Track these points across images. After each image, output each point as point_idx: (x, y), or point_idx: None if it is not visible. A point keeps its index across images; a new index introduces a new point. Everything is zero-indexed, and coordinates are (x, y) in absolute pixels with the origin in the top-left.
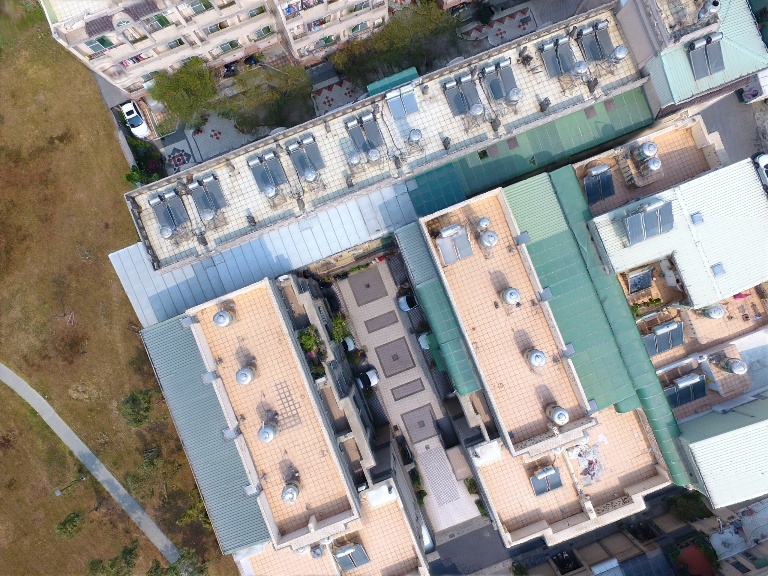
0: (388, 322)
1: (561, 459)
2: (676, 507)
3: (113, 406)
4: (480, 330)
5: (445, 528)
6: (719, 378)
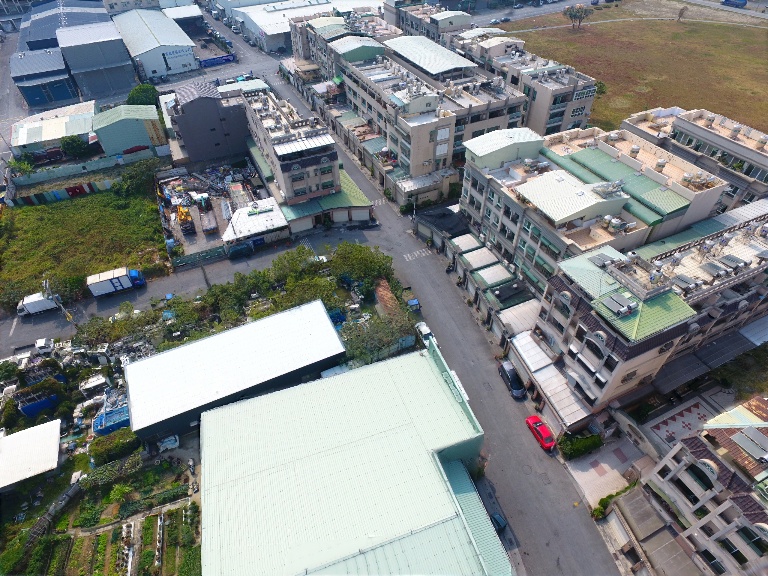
0: None
1: None
2: None
3: None
4: None
5: None
6: None
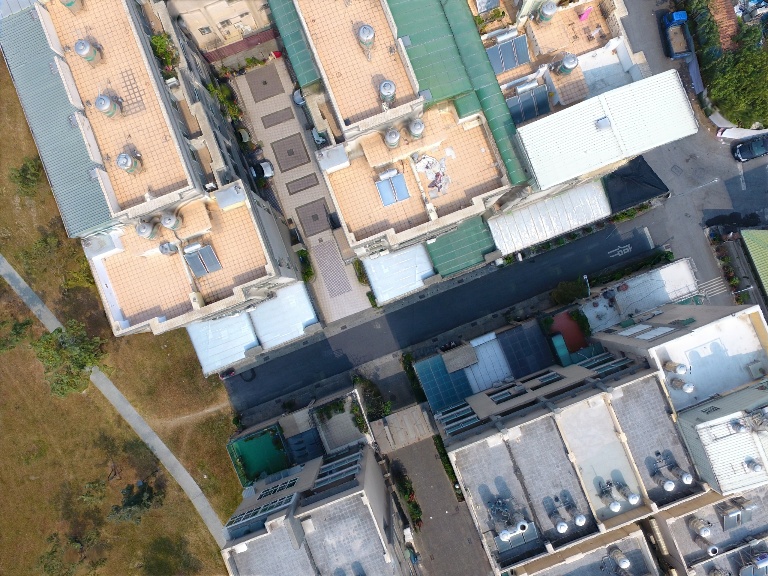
0: (284, 118)
1: (410, 172)
2: (557, 289)
3: (16, 202)
4: (320, 22)
5: (337, 319)
6: (559, 86)
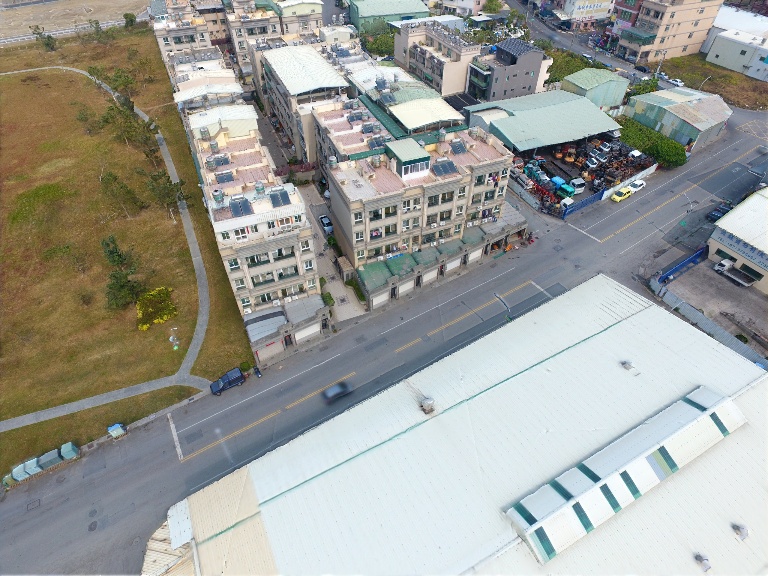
0: None
1: None
2: None
3: None
4: None
5: None
6: None
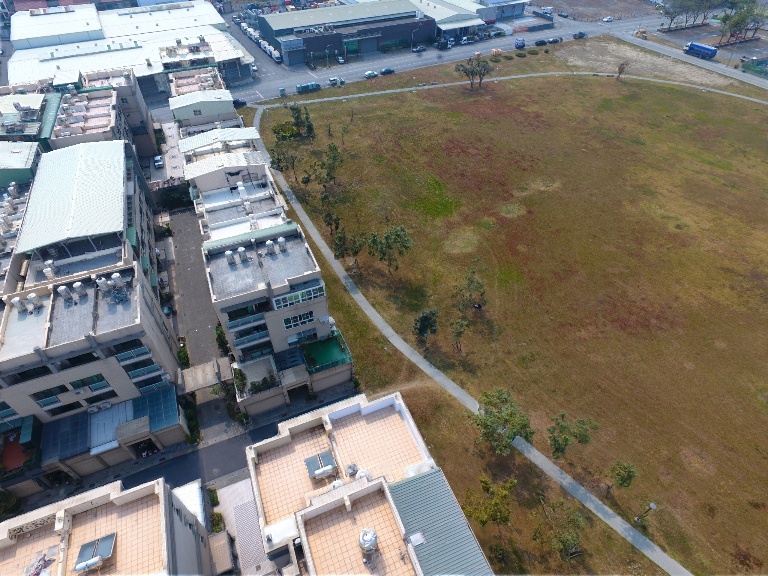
0: None
1: None
2: (7, 506)
3: None
4: None
5: None
6: None
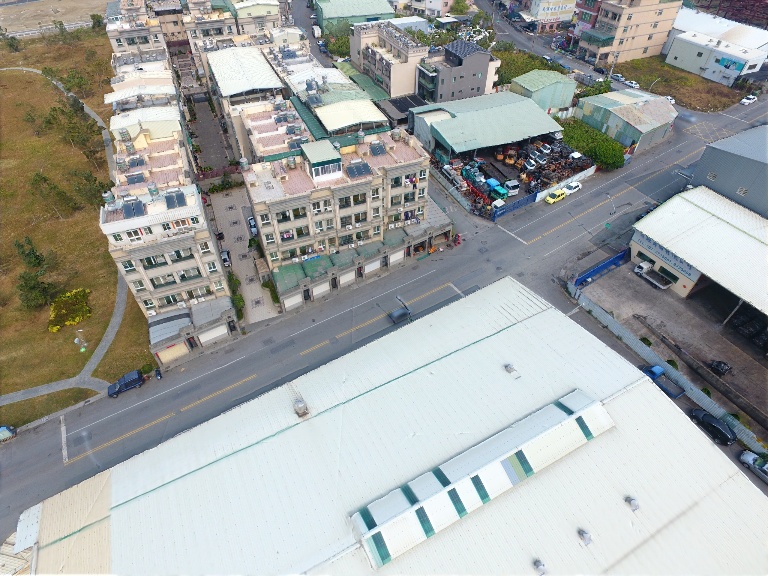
0: None
1: None
2: None
3: None
4: None
5: None
6: None
